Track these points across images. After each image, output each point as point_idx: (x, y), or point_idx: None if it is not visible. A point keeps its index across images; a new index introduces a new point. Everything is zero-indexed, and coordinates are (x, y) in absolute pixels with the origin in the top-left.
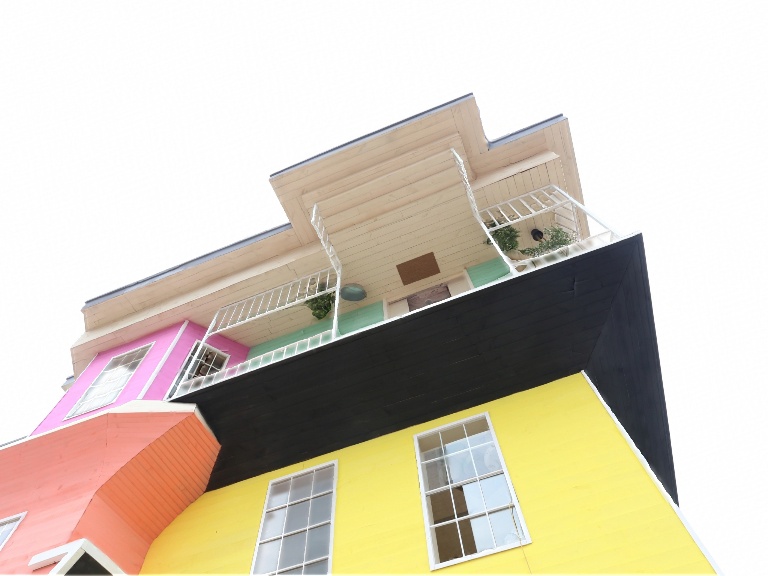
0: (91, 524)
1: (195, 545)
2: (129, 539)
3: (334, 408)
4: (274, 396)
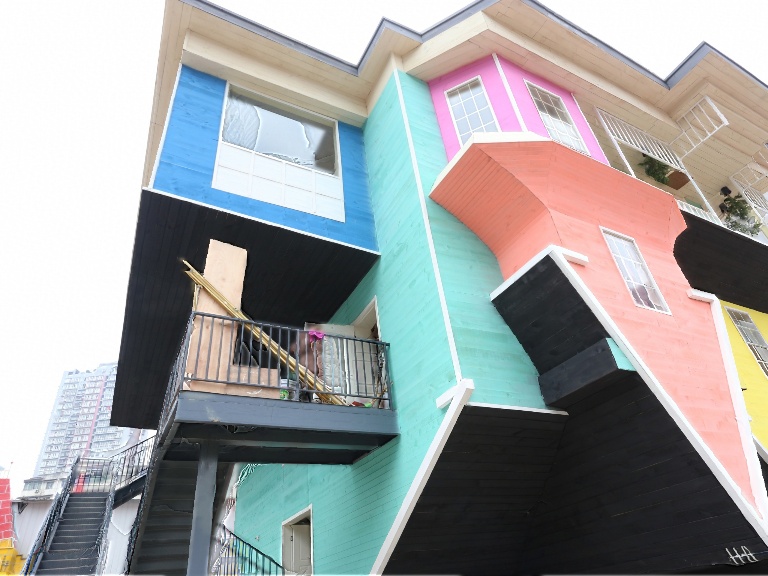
0: None
1: None
2: None
3: (707, 268)
4: (696, 241)
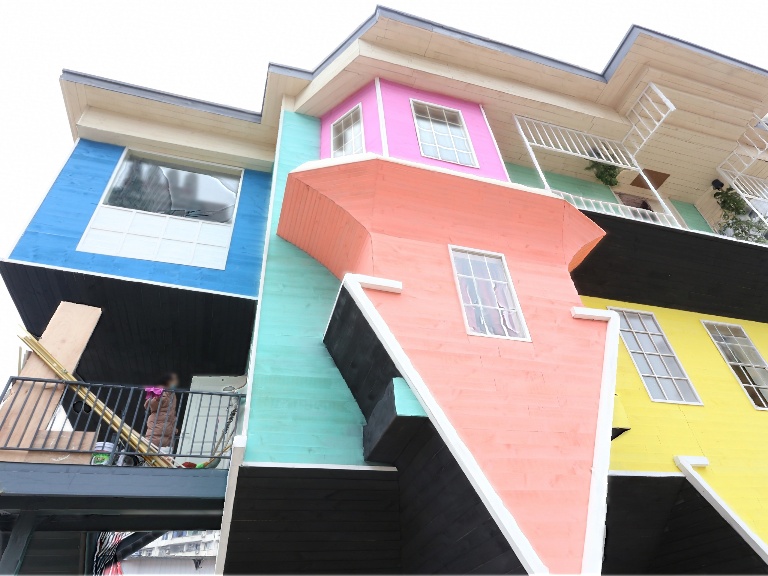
0: None
1: None
2: None
3: (665, 277)
4: (637, 247)
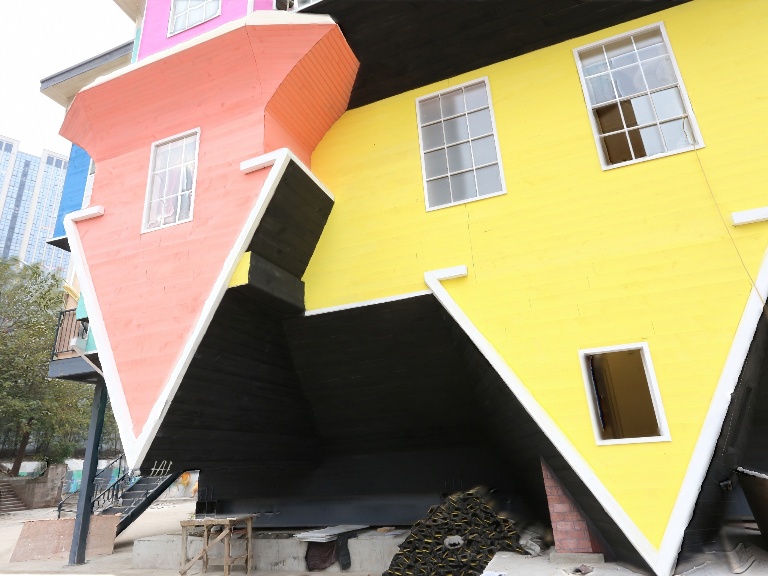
0: (271, 137)
1: (357, 156)
2: (297, 151)
3: (486, 19)
4: (418, 4)
